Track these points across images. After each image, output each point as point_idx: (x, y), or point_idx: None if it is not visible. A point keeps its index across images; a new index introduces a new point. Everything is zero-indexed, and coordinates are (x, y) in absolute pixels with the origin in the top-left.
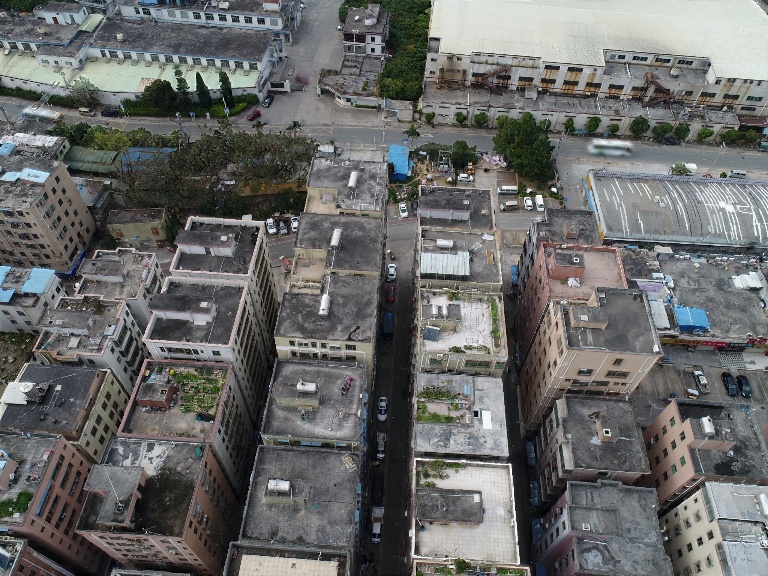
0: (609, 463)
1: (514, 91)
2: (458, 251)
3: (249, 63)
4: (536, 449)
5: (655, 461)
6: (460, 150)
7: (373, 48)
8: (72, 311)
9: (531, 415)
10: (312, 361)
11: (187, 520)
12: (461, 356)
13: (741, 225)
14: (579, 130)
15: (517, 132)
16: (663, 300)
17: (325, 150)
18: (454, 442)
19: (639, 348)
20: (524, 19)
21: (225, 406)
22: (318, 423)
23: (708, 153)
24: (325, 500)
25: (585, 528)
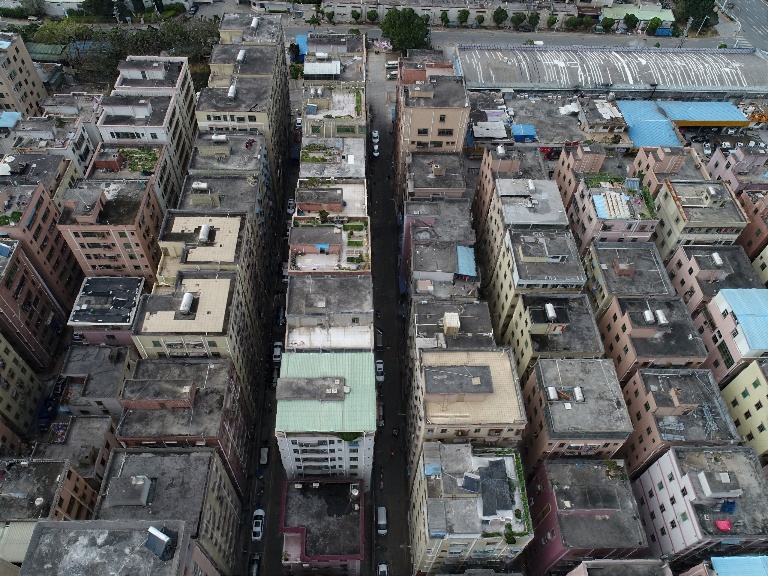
0: None
1: None
2: (332, 61)
3: None
4: (402, 211)
5: (480, 200)
6: None
7: None
8: (40, 121)
9: (397, 188)
10: (225, 131)
11: (137, 217)
12: (332, 122)
13: (569, 75)
14: (452, 22)
15: (398, 17)
16: (503, 121)
17: None
18: (327, 172)
19: None
20: None
21: (163, 171)
22: (229, 164)
23: (556, 36)
24: (234, 201)
25: (416, 213)
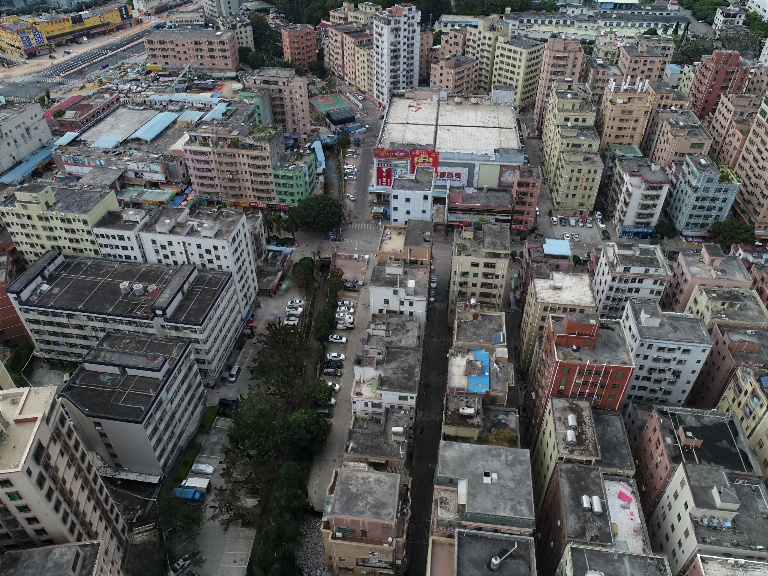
0: None
1: None
2: None
3: None
4: None
5: None
6: None
7: (738, 22)
8: None
9: None
10: None
11: None
12: None
13: None
14: None
15: None
16: None
17: None
18: None
19: None
20: None
21: None
22: None
23: None
24: None
25: None
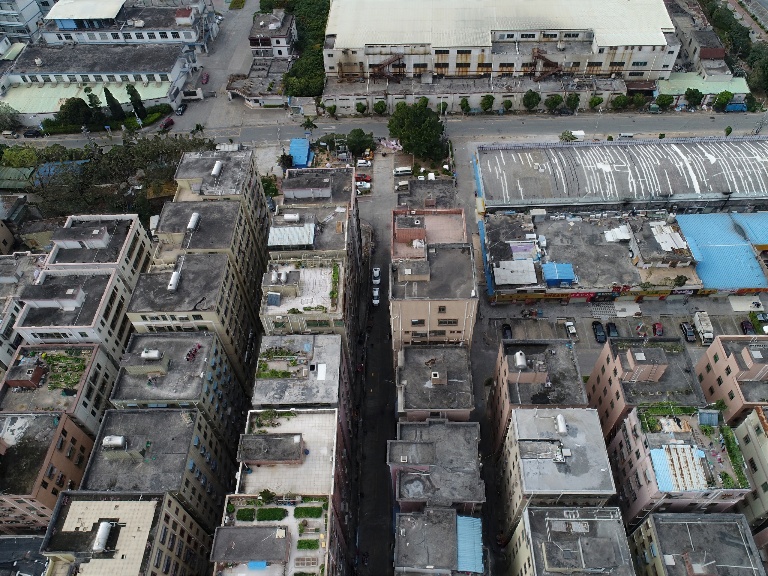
0: (439, 403)
1: (412, 78)
2: (305, 223)
3: (160, 75)
4: None
5: (497, 402)
6: (356, 138)
7: (280, 50)
8: None
9: (394, 372)
10: (165, 333)
11: (37, 480)
12: (299, 317)
13: (617, 183)
14: (474, 109)
15: (406, 115)
16: (533, 258)
17: (229, 149)
18: (289, 394)
19: (459, 295)
20: (417, 9)
21: (92, 382)
22: (164, 387)
23: (600, 120)
24: (162, 453)
25: (403, 460)
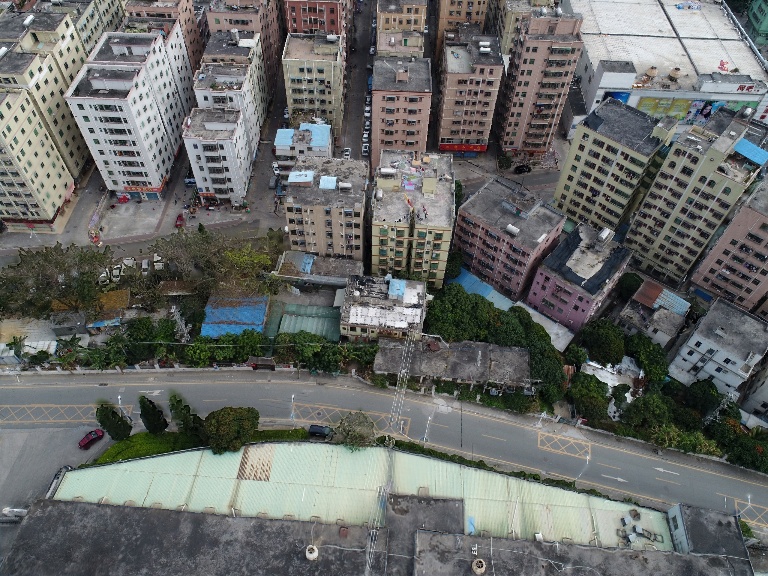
0: None
1: None
2: None
3: None
4: None
5: None
6: None
7: None
8: (225, 74)
9: None
10: None
11: None
12: None
13: None
14: None
15: None
16: None
17: None
18: None
19: None
20: None
21: None
22: None
23: None
24: None
25: None
